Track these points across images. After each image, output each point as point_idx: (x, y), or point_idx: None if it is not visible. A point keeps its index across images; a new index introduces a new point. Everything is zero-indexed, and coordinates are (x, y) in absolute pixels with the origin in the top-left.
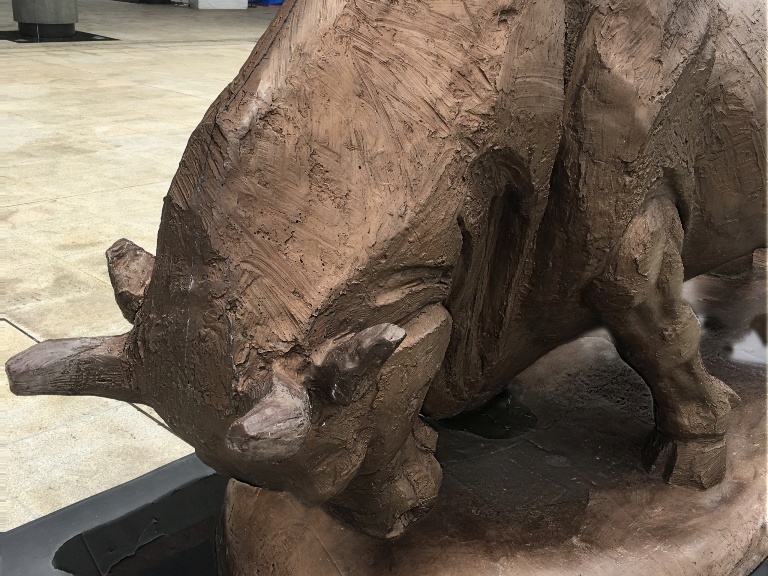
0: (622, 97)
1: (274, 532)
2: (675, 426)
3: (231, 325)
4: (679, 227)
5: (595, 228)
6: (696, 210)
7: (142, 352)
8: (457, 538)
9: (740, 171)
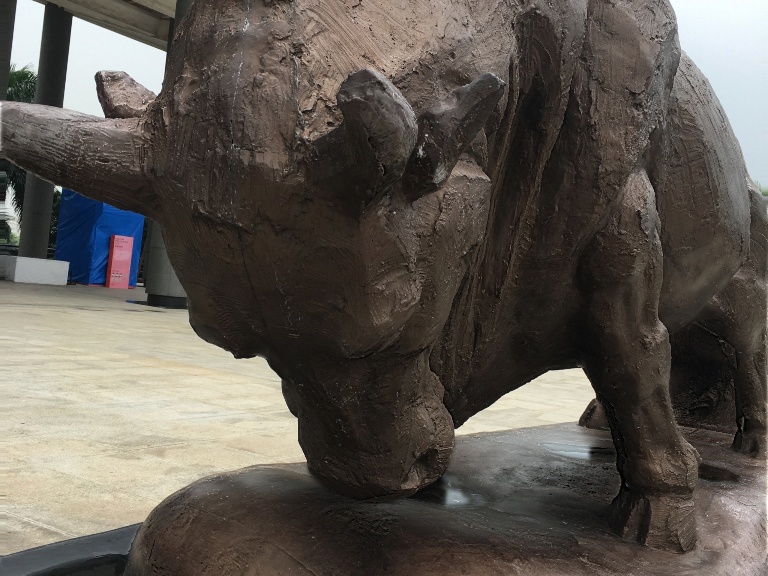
0: (627, 30)
1: (220, 551)
2: (647, 475)
3: (297, 67)
4: (658, 216)
5: (607, 159)
6: None
7: (167, 118)
8: (458, 540)
9: (695, 191)
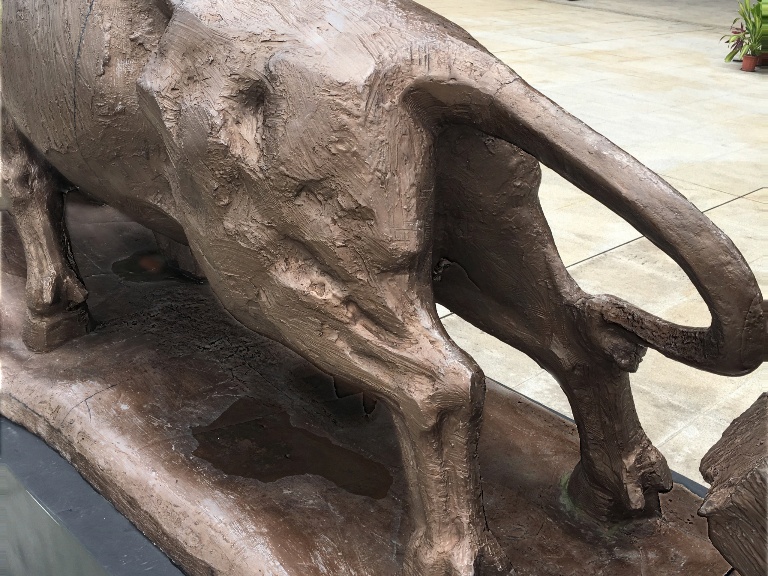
0: None
1: None
2: None
3: None
4: None
5: None
6: None
7: None
8: None
9: None
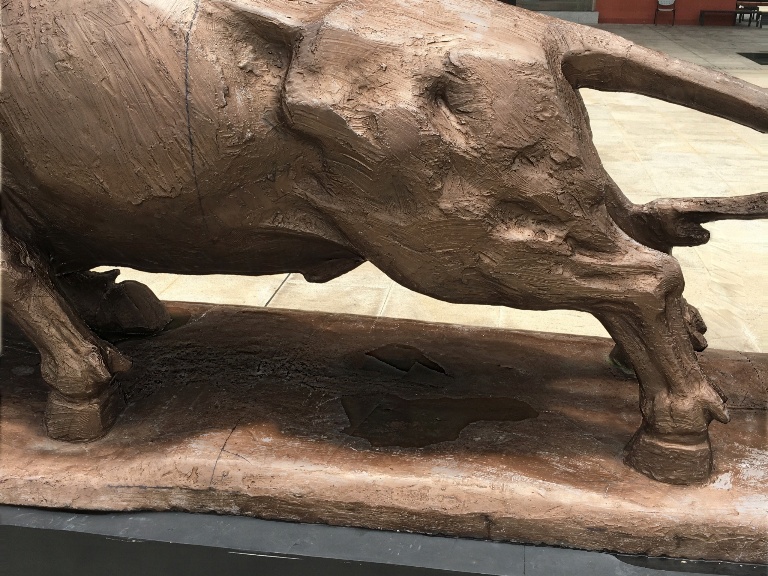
0: None
1: None
2: None
3: None
4: None
5: None
6: (6, 170)
7: None
8: None
9: (7, 139)
